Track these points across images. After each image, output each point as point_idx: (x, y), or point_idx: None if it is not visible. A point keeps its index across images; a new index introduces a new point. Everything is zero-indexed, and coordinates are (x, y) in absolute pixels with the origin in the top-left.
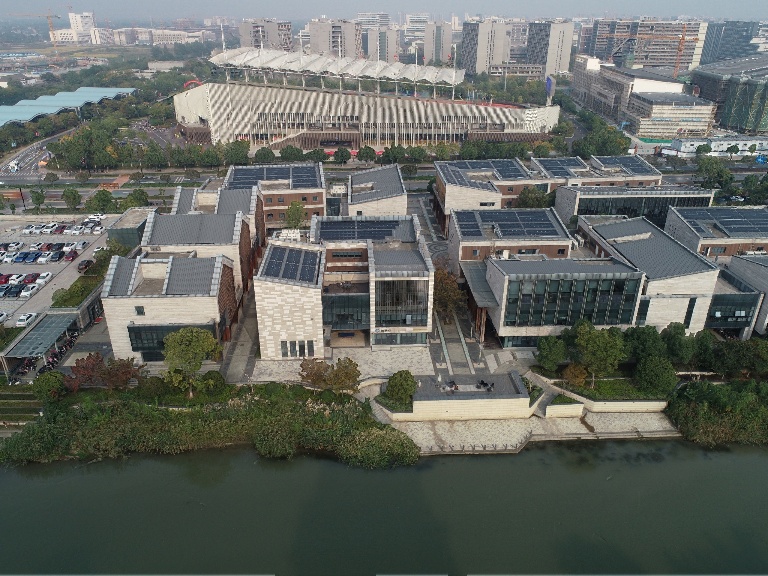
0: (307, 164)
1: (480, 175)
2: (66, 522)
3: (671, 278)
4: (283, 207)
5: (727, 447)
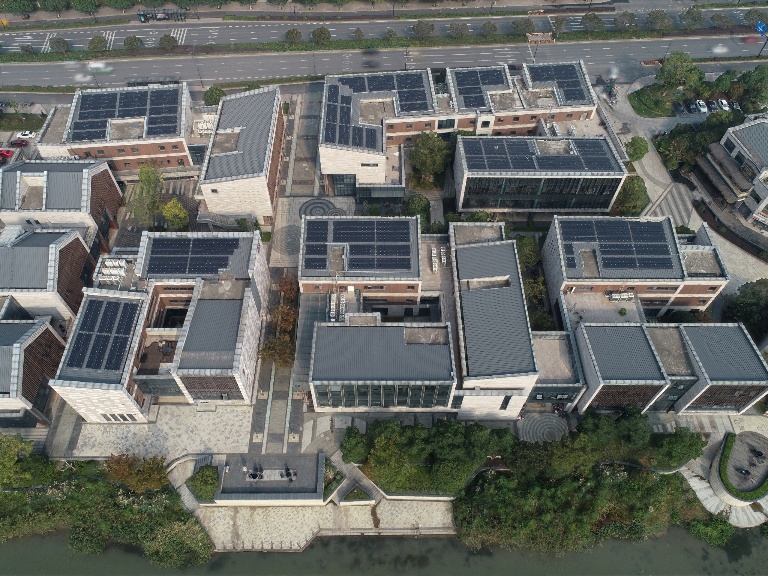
0: (169, 85)
1: (377, 101)
2: None
3: (488, 379)
4: (140, 156)
5: (491, 551)
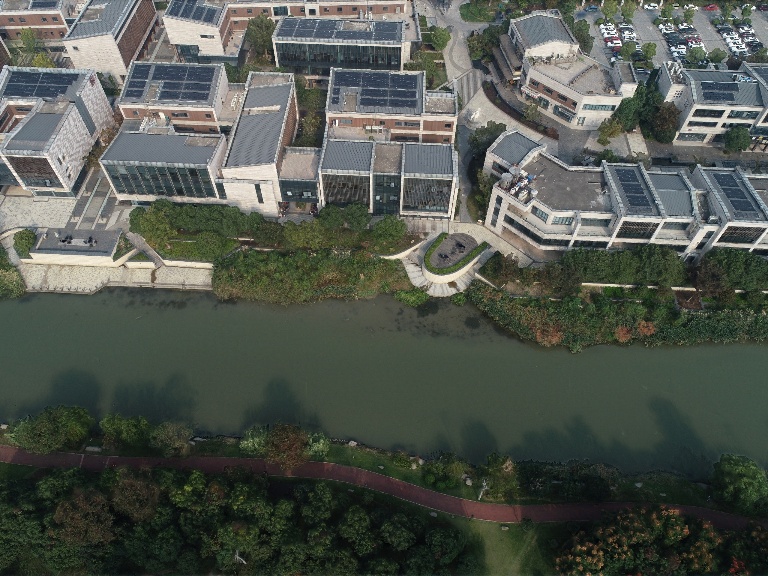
0: None
1: None
2: None
3: (238, 168)
4: (27, 27)
5: (235, 301)
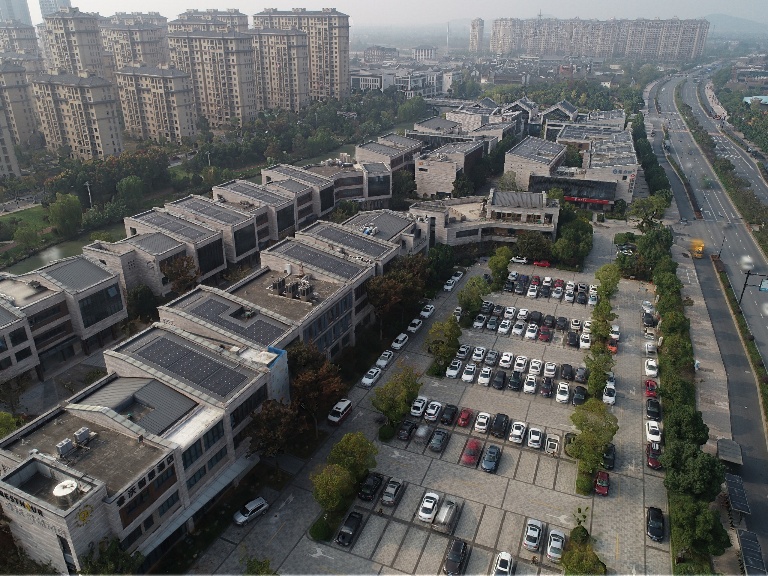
0: None
1: None
2: None
3: None
4: None
5: None
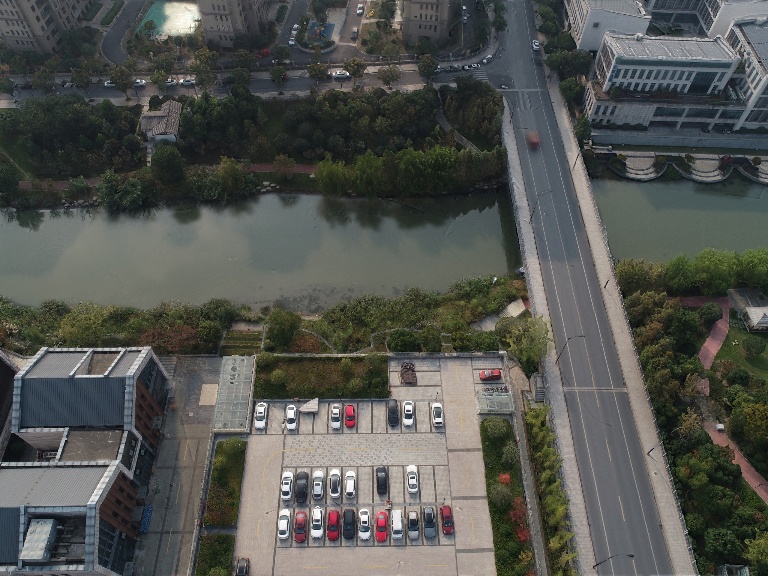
0: None
1: None
2: (186, 267)
3: None
4: None
5: None
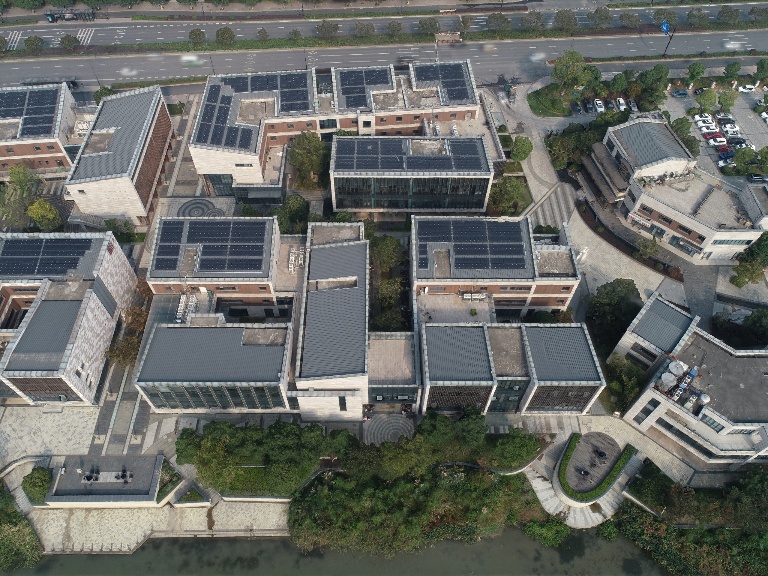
0: (48, 86)
1: (259, 101)
2: None
3: (318, 380)
4: (16, 157)
5: (322, 552)
